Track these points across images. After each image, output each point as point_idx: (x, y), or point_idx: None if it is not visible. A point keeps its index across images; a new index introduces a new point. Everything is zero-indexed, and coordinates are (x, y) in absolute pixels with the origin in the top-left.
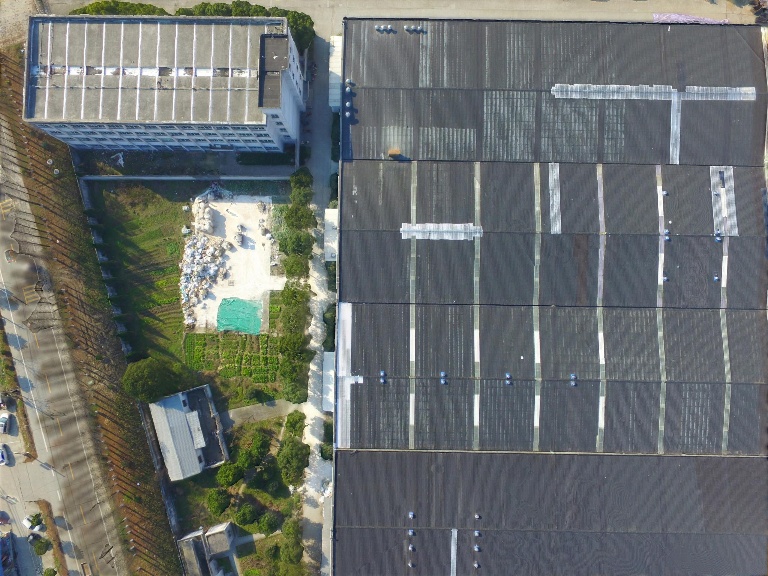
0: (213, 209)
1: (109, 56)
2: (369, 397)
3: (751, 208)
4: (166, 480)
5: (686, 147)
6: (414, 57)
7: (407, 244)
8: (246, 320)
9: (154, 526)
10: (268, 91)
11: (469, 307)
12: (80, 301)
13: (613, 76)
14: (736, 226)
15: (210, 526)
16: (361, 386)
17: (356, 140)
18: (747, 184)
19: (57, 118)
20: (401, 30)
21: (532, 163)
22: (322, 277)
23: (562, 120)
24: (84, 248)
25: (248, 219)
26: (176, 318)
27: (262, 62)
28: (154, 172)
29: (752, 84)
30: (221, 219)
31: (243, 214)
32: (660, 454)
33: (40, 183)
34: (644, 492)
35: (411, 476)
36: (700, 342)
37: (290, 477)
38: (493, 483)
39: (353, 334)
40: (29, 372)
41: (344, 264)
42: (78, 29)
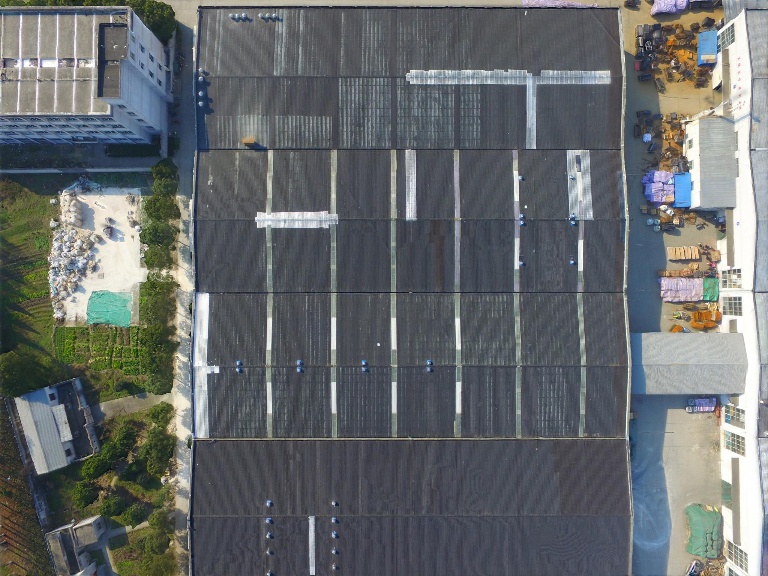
0: (81, 202)
1: None
2: (226, 387)
3: (607, 191)
4: (37, 474)
5: (542, 131)
6: (269, 45)
7: (263, 233)
8: (116, 313)
9: (25, 520)
10: (108, 81)
11: (327, 295)
12: None
13: (468, 61)
14: (591, 210)
15: (82, 519)
16: (217, 376)
17: (212, 130)
18: (603, 168)
19: None
20: (256, 18)
21: (389, 150)
22: None
23: (418, 106)
24: None
25: (117, 211)
26: (46, 312)
27: (102, 52)
28: (20, 165)
29: (607, 67)
30: (90, 212)
31: (112, 206)
32: (517, 438)
33: None
34: (501, 476)
35: (269, 464)
36: (556, 326)
37: (154, 468)
38: (351, 470)
39: (210, 324)
40: None
41: (200, 254)
42: None
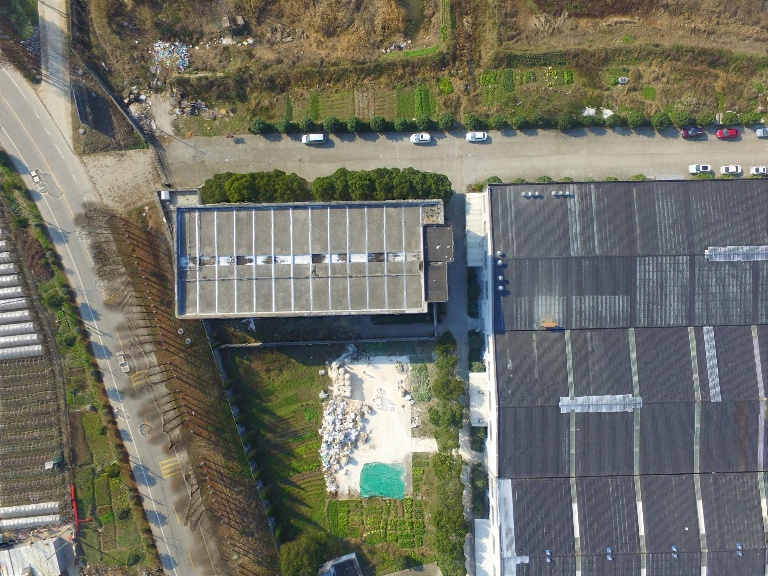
0: (350, 372)
1: (260, 245)
2: None
3: None
4: None
5: None
6: (563, 223)
7: (566, 418)
8: (389, 485)
9: None
10: (433, 283)
11: (630, 478)
12: (220, 474)
13: (765, 236)
14: None
15: None
16: (527, 566)
17: (508, 311)
18: None
19: (210, 312)
20: (548, 195)
21: (686, 327)
22: (464, 437)
23: (716, 283)
24: (221, 419)
25: (386, 380)
26: (317, 485)
27: (425, 253)
28: (289, 338)
29: None
30: (359, 382)
31: (381, 375)
32: None
33: (171, 353)
34: None
35: None
36: None
37: None
38: None
39: (515, 512)
40: (171, 549)
41: (503, 441)
42: (226, 218)
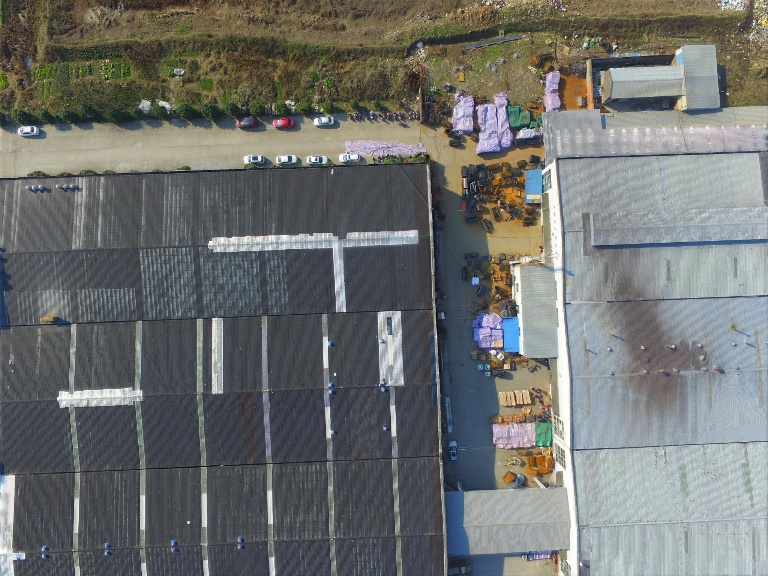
0: None
1: None
2: (33, 573)
3: (418, 354)
4: None
5: (352, 294)
6: (68, 217)
7: (66, 413)
8: None
9: None
10: None
11: (136, 472)
12: None
13: (273, 226)
14: (402, 374)
15: None
16: (24, 562)
17: (12, 306)
18: (415, 329)
19: None
20: (55, 188)
21: (195, 319)
22: None
23: (222, 274)
24: None
25: None
26: None
27: None
28: None
29: (415, 227)
30: None
31: None
32: None
33: None
34: None
35: None
36: (370, 495)
37: None
38: None
39: (16, 508)
40: None
41: (3, 436)
42: None
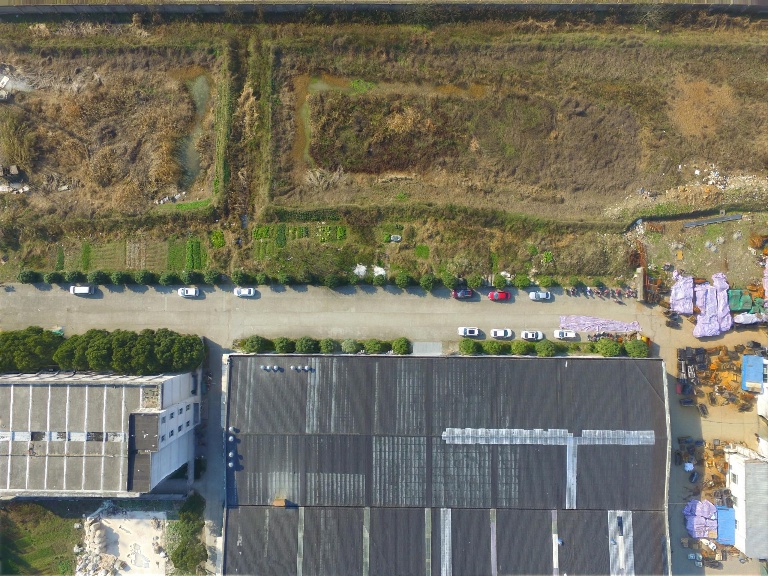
0: (106, 526)
1: None
2: None
3: (650, 558)
4: None
5: (583, 492)
6: (301, 398)
7: None
8: None
9: None
10: (138, 472)
11: None
12: None
13: (507, 419)
14: None
15: None
16: None
17: (241, 486)
18: (646, 531)
19: None
20: (288, 368)
21: (423, 508)
22: None
23: (454, 465)
24: None
25: (142, 536)
26: None
27: (132, 441)
28: None
29: (651, 427)
30: (114, 536)
31: (137, 531)
32: None
33: None
34: None
35: None
36: None
37: None
38: None
39: None
40: None
41: None
42: None
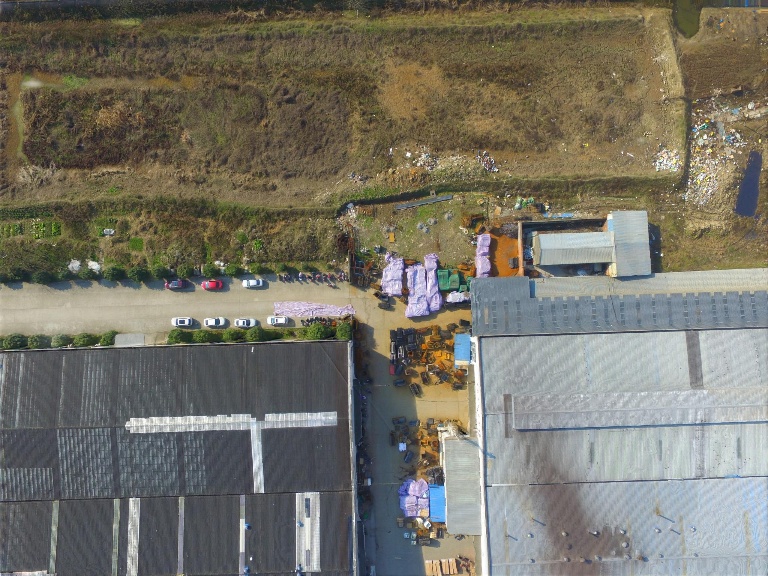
0: None
1: None
2: None
3: (335, 538)
4: None
5: (270, 475)
6: None
7: None
8: None
9: None
10: None
11: None
12: None
13: (191, 406)
14: (319, 560)
15: None
16: None
17: None
18: (333, 511)
19: None
20: None
21: (113, 499)
22: None
23: (140, 455)
24: None
25: None
26: None
27: None
28: None
29: (334, 408)
30: None
31: None
32: None
33: None
34: None
35: None
36: None
37: None
38: None
39: None
40: None
41: None
42: None
